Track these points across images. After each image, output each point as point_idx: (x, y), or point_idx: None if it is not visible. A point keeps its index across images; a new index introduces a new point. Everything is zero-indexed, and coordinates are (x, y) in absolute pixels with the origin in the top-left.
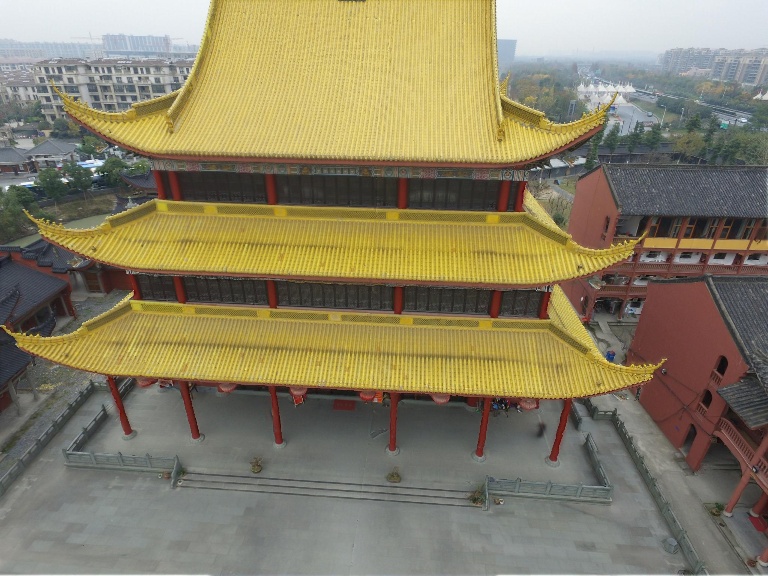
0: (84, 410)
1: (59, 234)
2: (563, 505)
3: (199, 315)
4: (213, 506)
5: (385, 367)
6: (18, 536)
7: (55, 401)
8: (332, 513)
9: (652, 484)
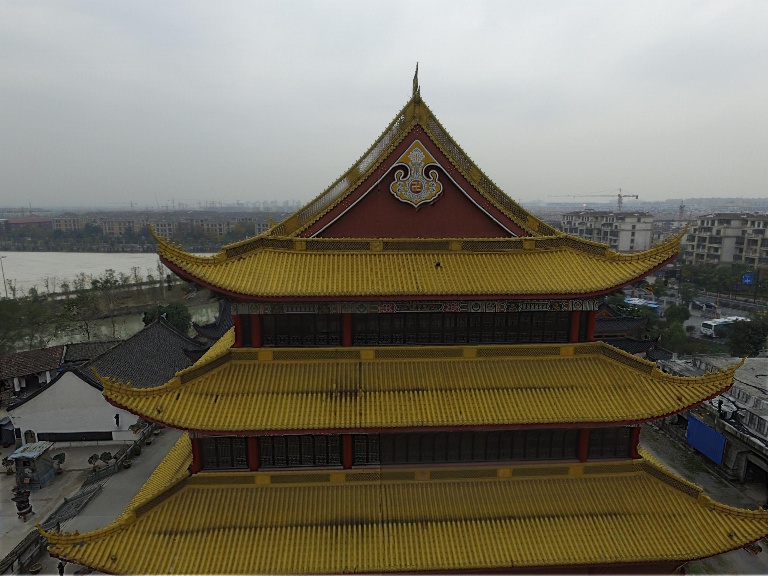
0: None
1: None
2: None
3: None
4: None
5: None
6: None
7: None
8: None
9: None
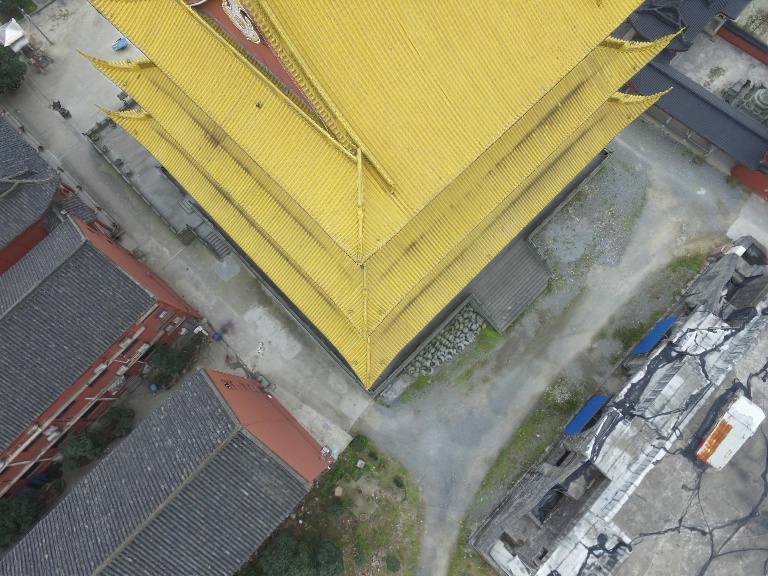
0: None
1: None
2: None
3: None
4: None
5: None
6: None
7: None
8: None
9: None
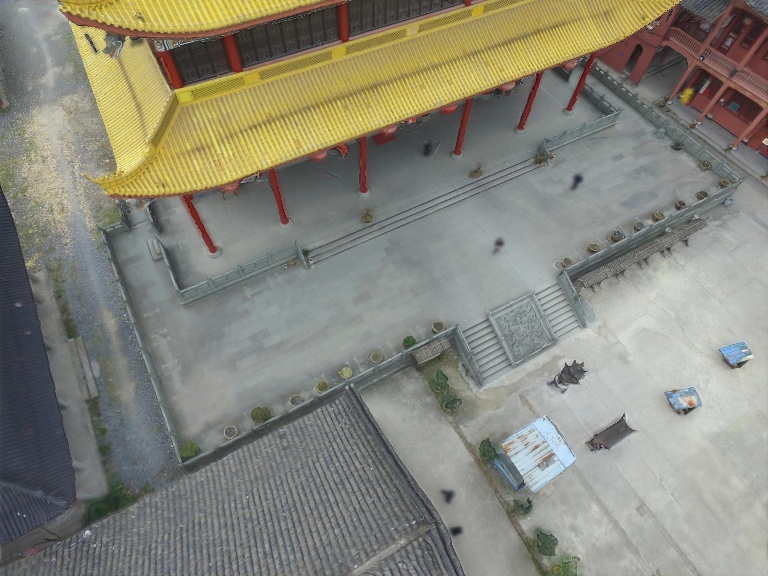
0: (125, 259)
1: (83, 5)
2: (589, 139)
3: (265, 81)
4: (357, 262)
5: (481, 67)
6: (215, 369)
7: (59, 272)
8: (451, 219)
9: (634, 99)
